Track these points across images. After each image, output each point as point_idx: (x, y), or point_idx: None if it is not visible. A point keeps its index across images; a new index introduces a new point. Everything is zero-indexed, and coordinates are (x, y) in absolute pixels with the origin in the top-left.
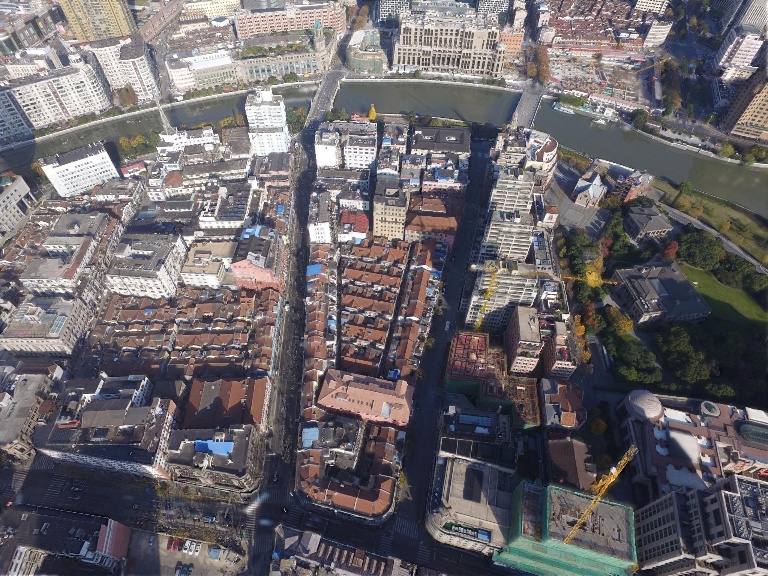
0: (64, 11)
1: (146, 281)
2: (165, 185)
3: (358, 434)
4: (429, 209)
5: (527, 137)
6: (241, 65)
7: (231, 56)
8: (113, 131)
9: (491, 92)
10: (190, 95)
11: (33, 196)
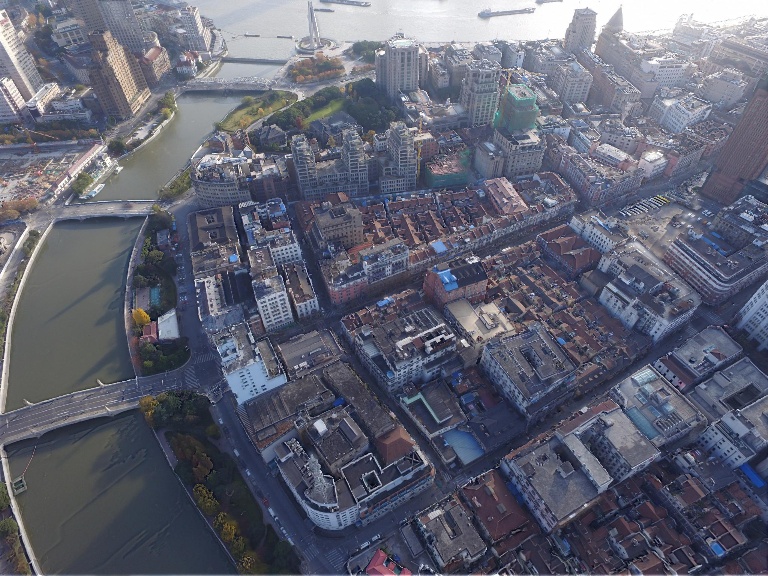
0: None
1: None
2: (415, 445)
3: None
4: None
5: None
6: None
7: None
8: None
9: None
10: None
11: None
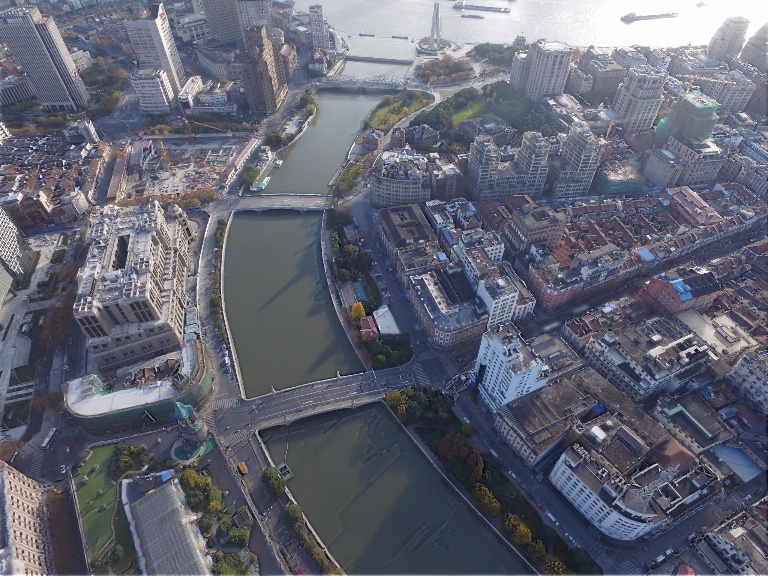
0: None
1: None
2: None
3: None
4: None
5: None
6: None
7: None
8: None
9: None
10: None
11: None
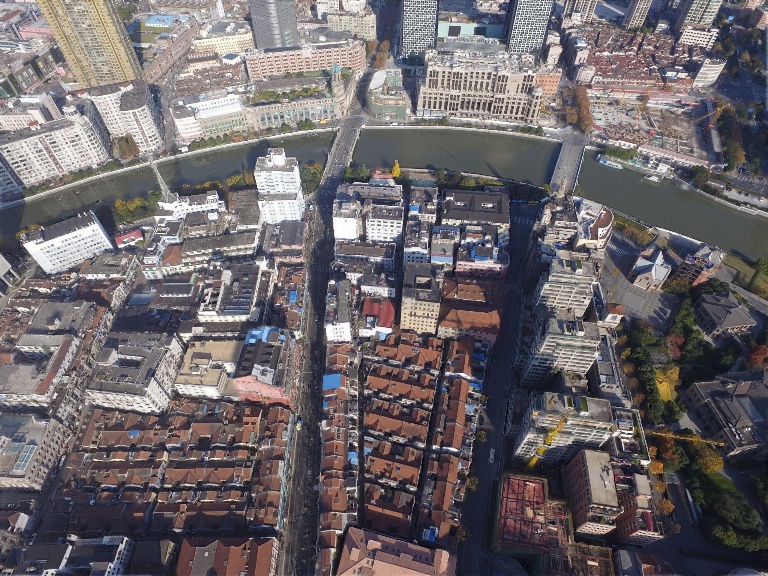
0: (63, 53)
1: (132, 398)
2: (162, 263)
3: None
4: (465, 297)
5: (577, 207)
6: (252, 112)
7: (241, 102)
8: (112, 184)
9: (526, 140)
10: (196, 146)
11: (15, 272)
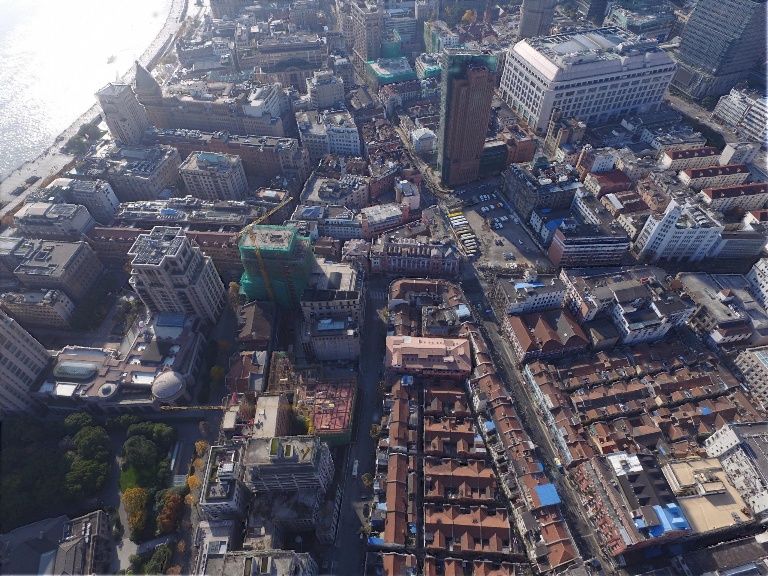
0: None
1: None
2: None
3: (426, 321)
4: None
5: None
6: None
7: None
8: None
9: None
10: None
11: None
